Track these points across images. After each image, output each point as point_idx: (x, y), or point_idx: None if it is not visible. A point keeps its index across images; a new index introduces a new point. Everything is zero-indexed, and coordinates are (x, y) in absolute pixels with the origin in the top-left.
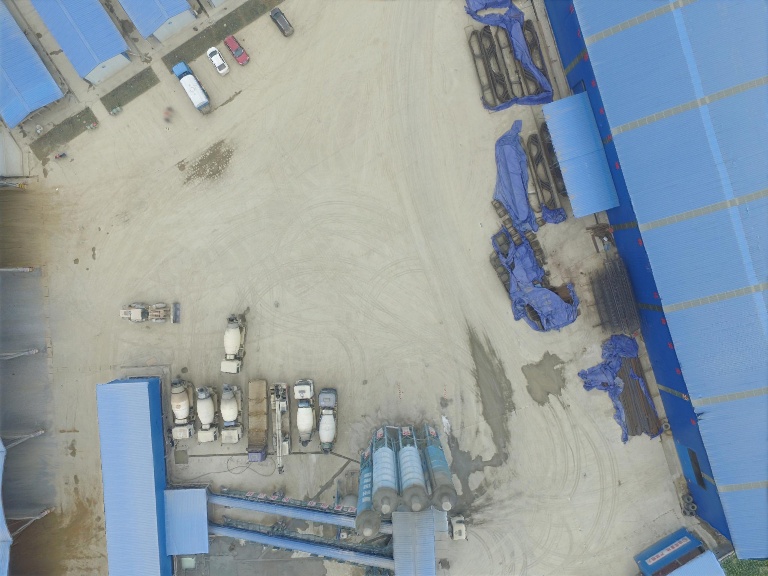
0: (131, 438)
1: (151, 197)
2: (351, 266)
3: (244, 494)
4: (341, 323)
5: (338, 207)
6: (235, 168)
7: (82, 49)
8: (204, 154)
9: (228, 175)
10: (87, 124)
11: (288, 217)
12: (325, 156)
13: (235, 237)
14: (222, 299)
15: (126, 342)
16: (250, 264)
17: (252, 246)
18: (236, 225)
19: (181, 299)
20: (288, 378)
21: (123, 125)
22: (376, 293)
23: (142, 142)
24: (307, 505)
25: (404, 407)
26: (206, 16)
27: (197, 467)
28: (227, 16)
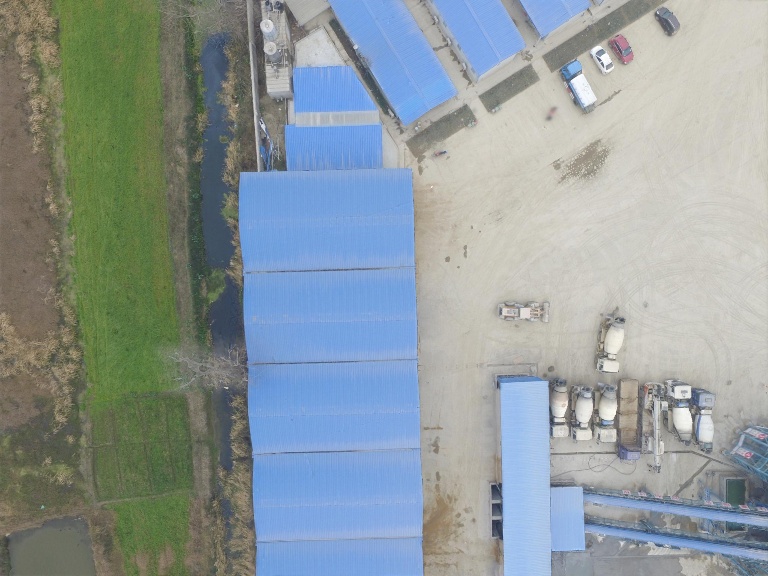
0: (530, 436)
1: (525, 196)
2: (721, 267)
3: (617, 492)
4: (709, 324)
5: (712, 208)
6: (610, 168)
7: (484, 46)
8: (580, 153)
9: (603, 175)
10: (465, 122)
11: (661, 217)
12: (701, 157)
13: (607, 237)
14: (592, 299)
15: (494, 340)
16: (621, 264)
17: (624, 246)
18: (609, 225)
19: (551, 298)
20: (653, 378)
21: (501, 123)
22: (745, 294)
23: (519, 140)
24: (706, 504)
25: (767, 408)
26: (589, 14)
27: (559, 465)
28: (610, 14)
